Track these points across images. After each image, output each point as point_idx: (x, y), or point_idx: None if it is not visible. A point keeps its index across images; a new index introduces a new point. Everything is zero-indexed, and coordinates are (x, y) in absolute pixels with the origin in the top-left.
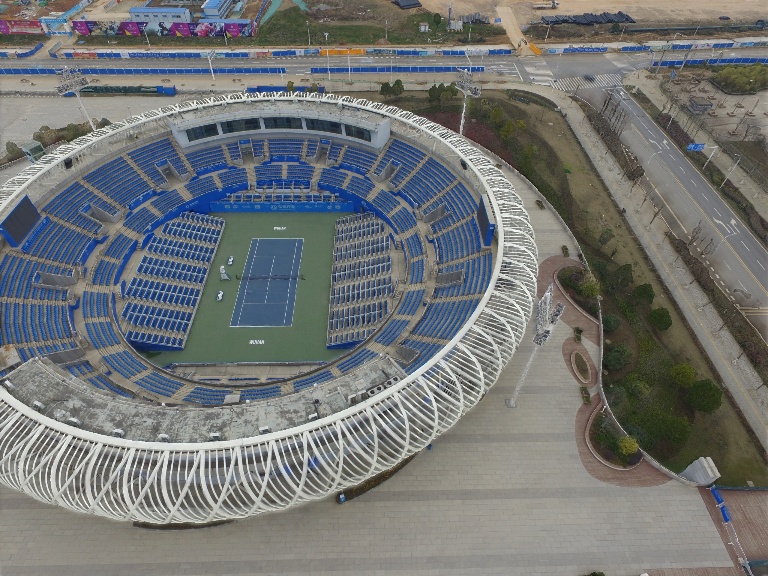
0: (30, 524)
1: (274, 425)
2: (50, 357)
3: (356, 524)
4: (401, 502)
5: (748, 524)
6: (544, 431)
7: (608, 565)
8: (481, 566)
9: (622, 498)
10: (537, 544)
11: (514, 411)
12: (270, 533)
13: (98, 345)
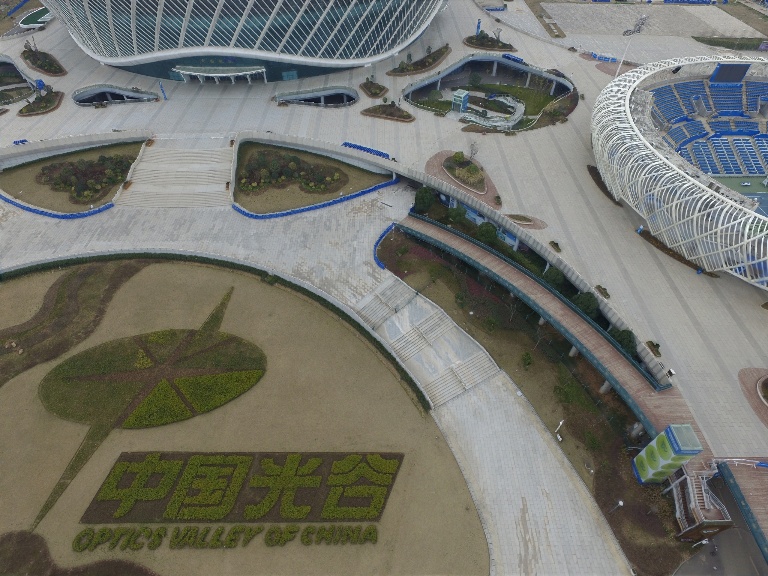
0: (573, 139)
1: (672, 163)
2: (653, 115)
3: (628, 238)
4: (652, 258)
5: (767, 489)
6: (762, 346)
7: (668, 363)
8: (633, 292)
9: (731, 388)
10: (662, 323)
11: (767, 329)
12: (606, 207)
13: (670, 134)
